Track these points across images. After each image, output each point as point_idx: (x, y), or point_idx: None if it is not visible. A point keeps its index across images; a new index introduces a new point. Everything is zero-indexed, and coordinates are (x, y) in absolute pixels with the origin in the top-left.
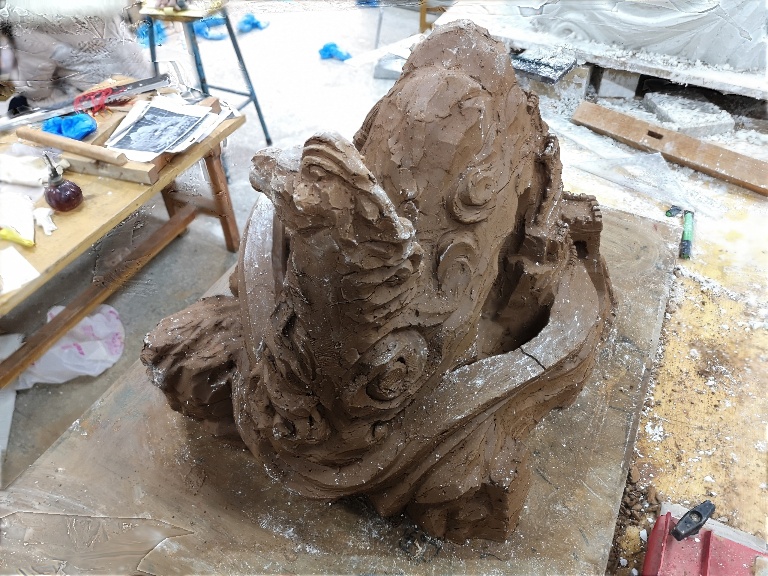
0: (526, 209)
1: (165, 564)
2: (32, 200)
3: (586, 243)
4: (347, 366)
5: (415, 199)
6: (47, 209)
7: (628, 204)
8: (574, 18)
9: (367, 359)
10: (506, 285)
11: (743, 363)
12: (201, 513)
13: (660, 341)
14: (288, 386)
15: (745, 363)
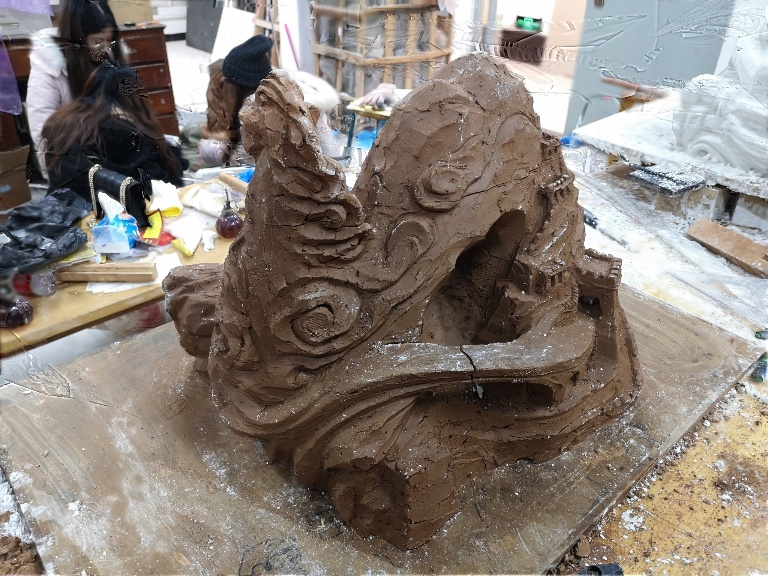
0: (522, 237)
1: (115, 458)
2: (207, 225)
3: (599, 301)
4: (274, 291)
5: (380, 174)
6: (213, 232)
7: (715, 318)
8: (710, 140)
9: (295, 293)
10: (491, 308)
11: None
12: (164, 433)
13: (683, 442)
14: (228, 300)
15: None
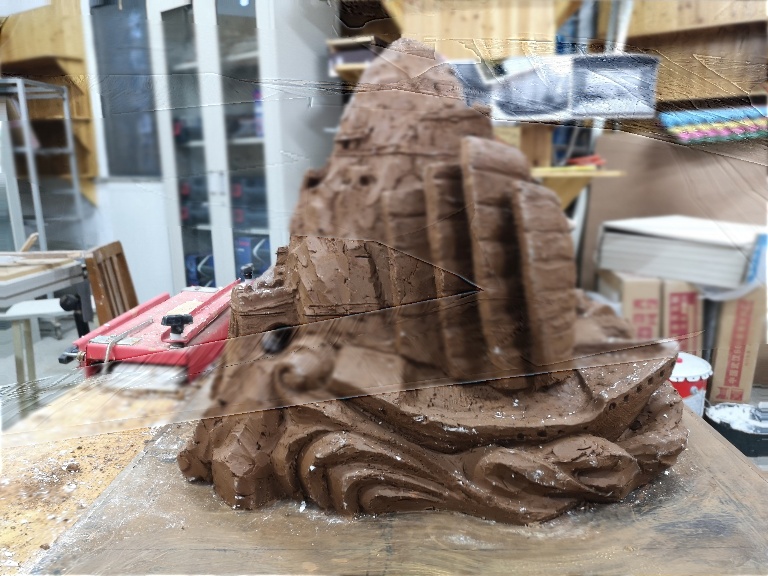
0: None
1: None
2: None
3: None
4: None
5: None
6: None
7: None
8: None
9: None
10: None
11: (5, 488)
12: None
13: None
14: None
15: (2, 488)
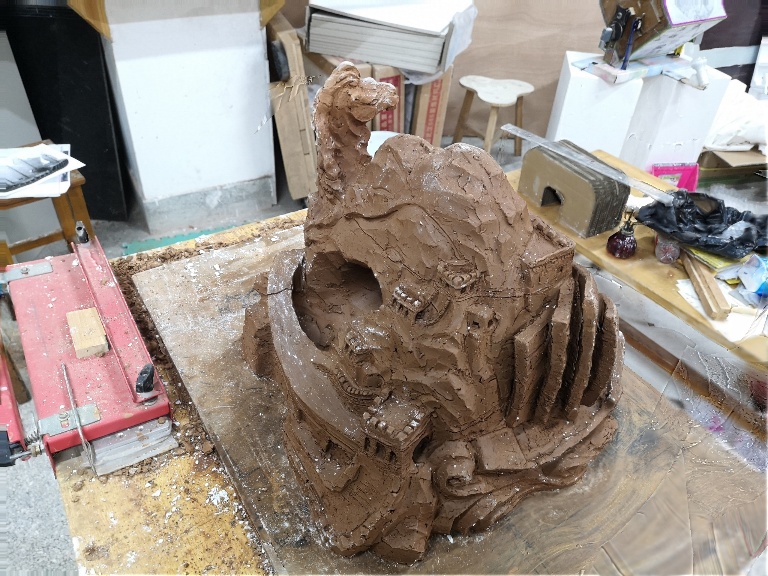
0: None
1: None
2: None
3: None
4: None
5: None
6: None
7: None
8: None
9: None
10: None
11: None
12: None
13: None
14: None
15: None
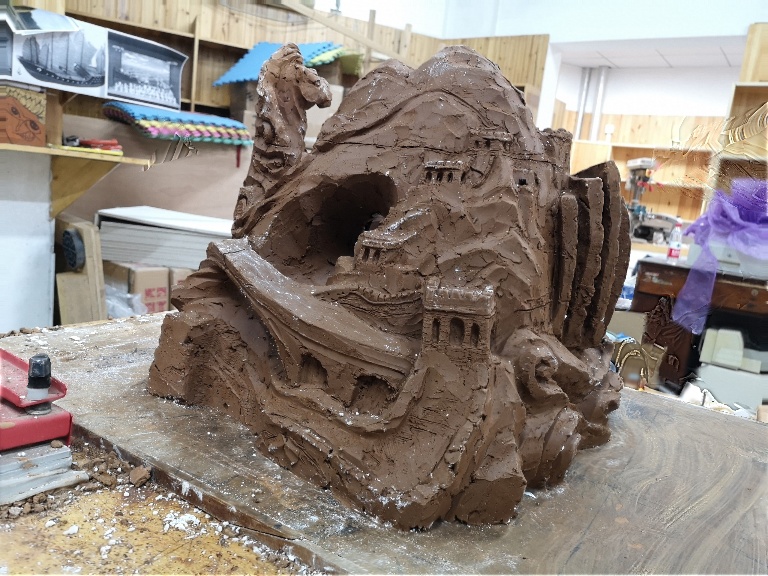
0: None
1: None
2: None
3: None
4: None
5: None
6: None
7: None
8: None
9: None
10: None
11: None
12: None
13: None
14: None
15: None
